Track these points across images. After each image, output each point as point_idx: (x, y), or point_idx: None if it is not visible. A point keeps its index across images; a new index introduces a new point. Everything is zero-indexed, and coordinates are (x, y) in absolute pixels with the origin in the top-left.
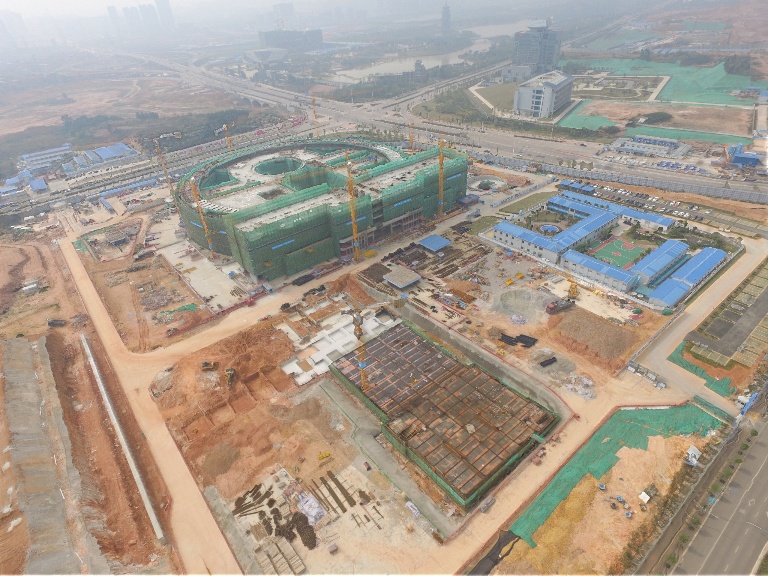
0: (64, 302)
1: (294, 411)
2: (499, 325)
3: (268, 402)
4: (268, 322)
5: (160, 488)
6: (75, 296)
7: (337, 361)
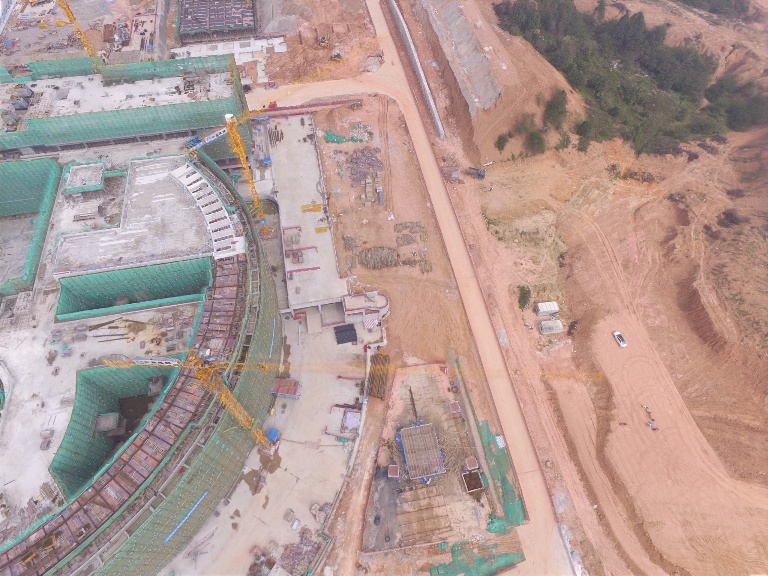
0: (480, 227)
1: (298, 9)
2: (126, 4)
3: (310, 24)
4: (271, 80)
5: (384, 8)
6: (467, 231)
7: (250, 25)
